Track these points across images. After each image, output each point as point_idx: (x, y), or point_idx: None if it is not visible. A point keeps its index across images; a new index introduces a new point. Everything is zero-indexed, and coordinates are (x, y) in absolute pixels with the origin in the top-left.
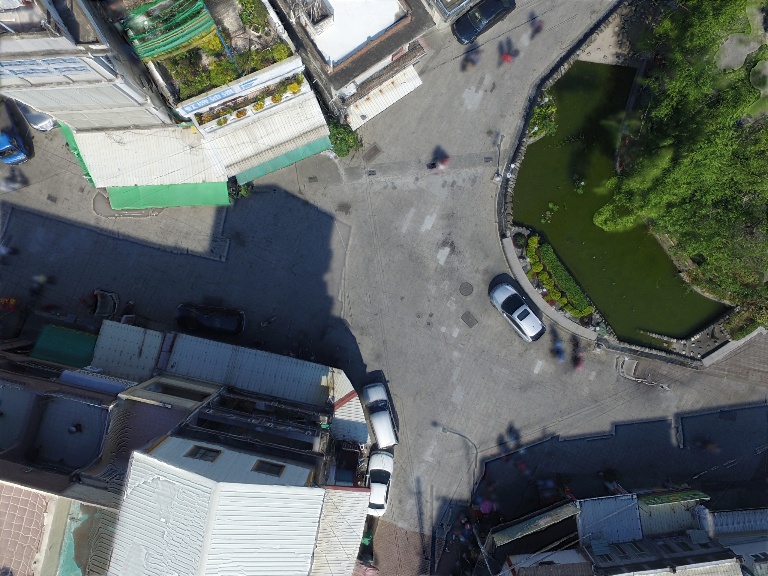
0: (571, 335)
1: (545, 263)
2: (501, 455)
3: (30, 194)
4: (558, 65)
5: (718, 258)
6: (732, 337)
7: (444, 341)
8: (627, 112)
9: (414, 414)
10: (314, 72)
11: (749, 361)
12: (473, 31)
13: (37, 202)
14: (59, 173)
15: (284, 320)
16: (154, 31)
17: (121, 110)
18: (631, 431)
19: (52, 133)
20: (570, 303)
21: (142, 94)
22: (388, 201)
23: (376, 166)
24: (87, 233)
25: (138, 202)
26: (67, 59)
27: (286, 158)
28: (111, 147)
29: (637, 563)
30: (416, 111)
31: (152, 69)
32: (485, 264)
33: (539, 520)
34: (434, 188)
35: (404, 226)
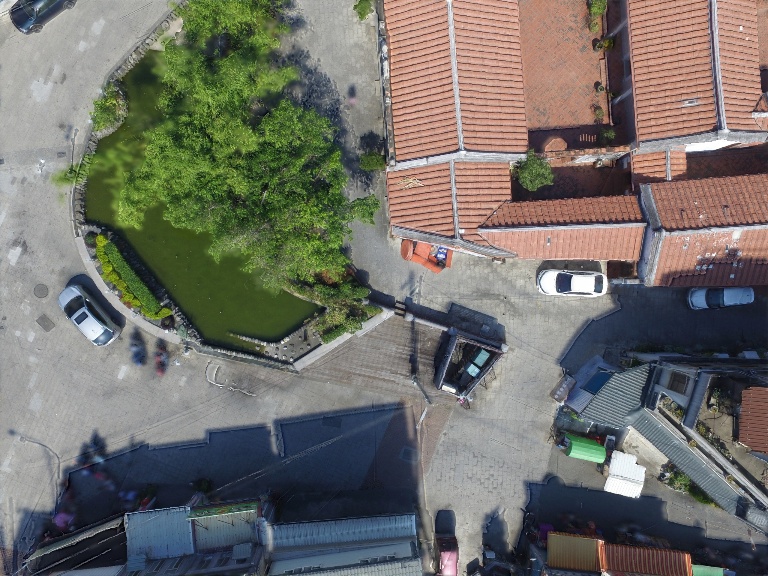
0: (158, 339)
1: None
2: (85, 465)
3: None
4: None
5: None
6: None
7: (19, 346)
8: None
9: None
10: None
11: (349, 365)
12: (27, 19)
13: None
14: None
15: None
16: None
17: None
18: (227, 439)
19: None
20: None
21: None
22: None
23: None
24: None
25: None
26: None
27: None
28: None
29: None
30: None
31: None
32: (61, 265)
33: (82, 534)
34: (2, 185)
35: None
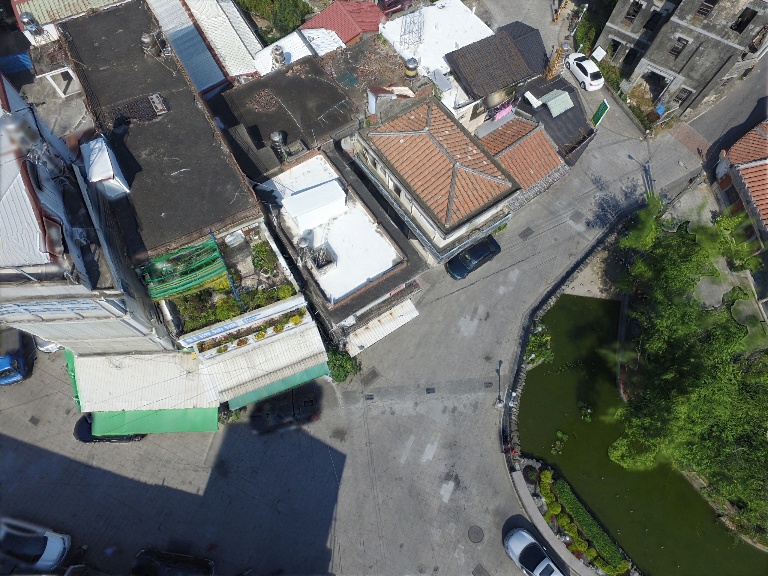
0: None
1: (563, 503)
2: None
3: (13, 416)
4: (546, 297)
5: (760, 503)
6: None
7: None
8: (620, 340)
9: None
10: (317, 305)
11: None
12: (464, 269)
13: (17, 424)
14: (50, 394)
15: (260, 573)
16: (170, 276)
17: (125, 339)
18: None
19: (56, 354)
20: (600, 555)
21: (148, 326)
22: (386, 427)
23: (374, 390)
24: (59, 460)
25: (121, 428)
26: (81, 301)
27: (282, 383)
28: (108, 371)
29: None
30: (414, 337)
31: (162, 305)
32: (495, 502)
33: None
34: (434, 414)
35: (403, 456)
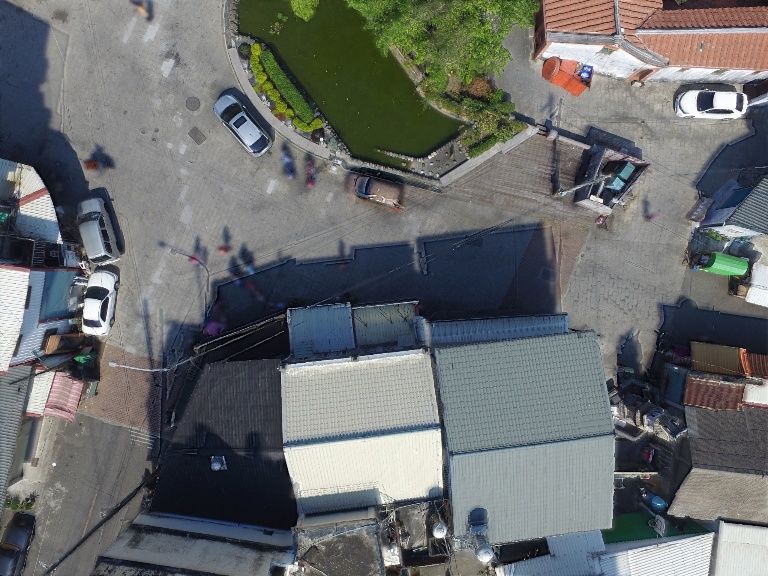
0: (306, 154)
1: None
2: (234, 278)
3: None
4: None
5: None
6: (470, 155)
7: (171, 158)
8: None
9: (141, 234)
10: None
11: (492, 183)
12: None
13: None
14: None
15: None
16: None
17: None
18: (371, 256)
19: None
20: (299, 117)
21: None
22: (108, 9)
23: None
24: None
25: None
26: None
27: None
28: None
29: (326, 358)
30: None
31: None
32: (213, 78)
33: None
34: None
35: (125, 36)
